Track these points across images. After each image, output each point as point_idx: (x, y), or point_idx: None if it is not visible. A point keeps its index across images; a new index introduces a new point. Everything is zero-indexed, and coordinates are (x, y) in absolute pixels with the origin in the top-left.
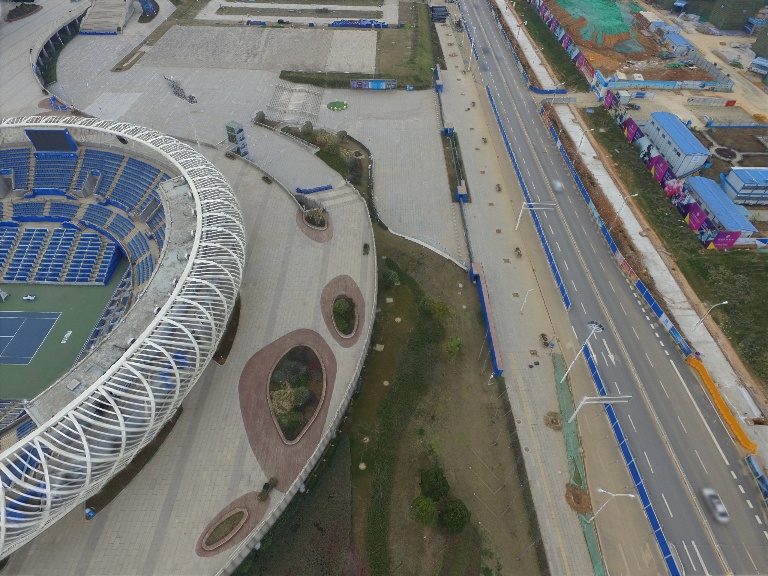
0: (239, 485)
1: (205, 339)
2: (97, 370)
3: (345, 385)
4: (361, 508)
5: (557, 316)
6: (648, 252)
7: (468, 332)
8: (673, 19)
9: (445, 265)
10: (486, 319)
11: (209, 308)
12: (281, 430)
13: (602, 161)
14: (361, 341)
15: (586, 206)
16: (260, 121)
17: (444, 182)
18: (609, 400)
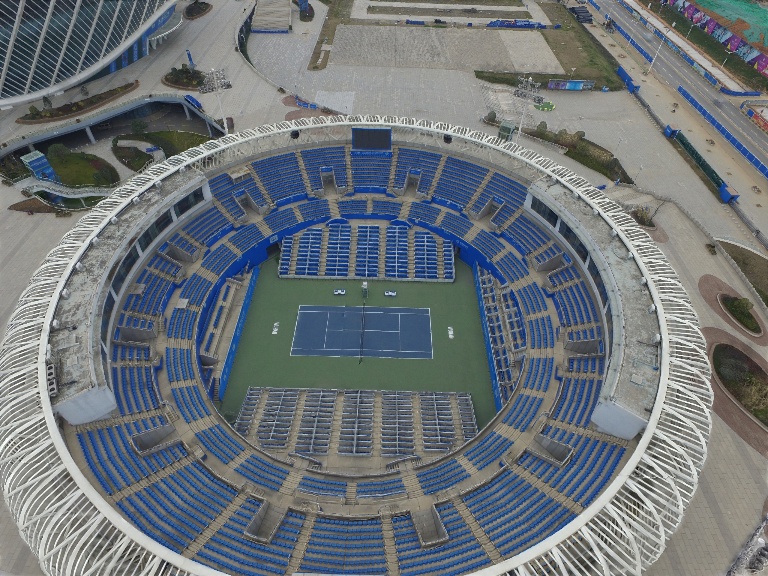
0: (763, 479)
1: None
2: (644, 365)
3: None
4: None
5: None
6: None
7: None
8: None
9: (767, 266)
10: None
11: None
12: (766, 426)
13: None
14: None
15: None
16: (492, 121)
17: (699, 183)
18: None
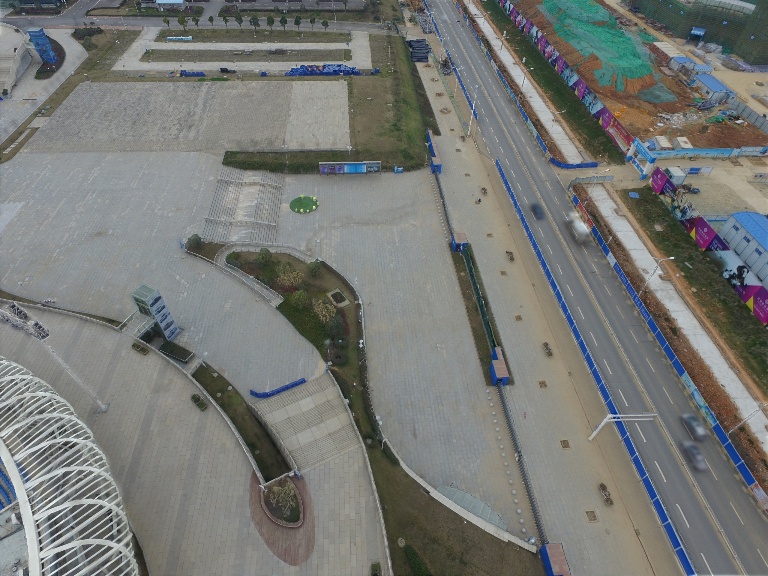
0: None
1: None
2: None
3: None
4: None
5: None
6: None
7: None
8: (693, 51)
9: (504, 557)
10: None
11: None
12: None
13: (673, 284)
14: None
15: (677, 377)
16: (194, 249)
17: (468, 343)
18: None
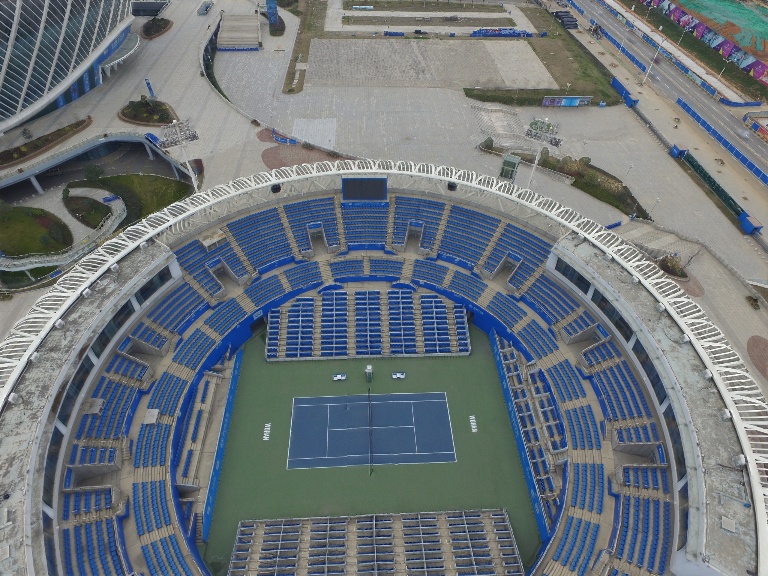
0: None
1: None
2: (732, 501)
3: None
4: None
5: None
6: None
7: None
8: None
9: None
10: None
11: None
12: None
13: None
14: None
15: None
16: (489, 148)
17: (717, 212)
18: None
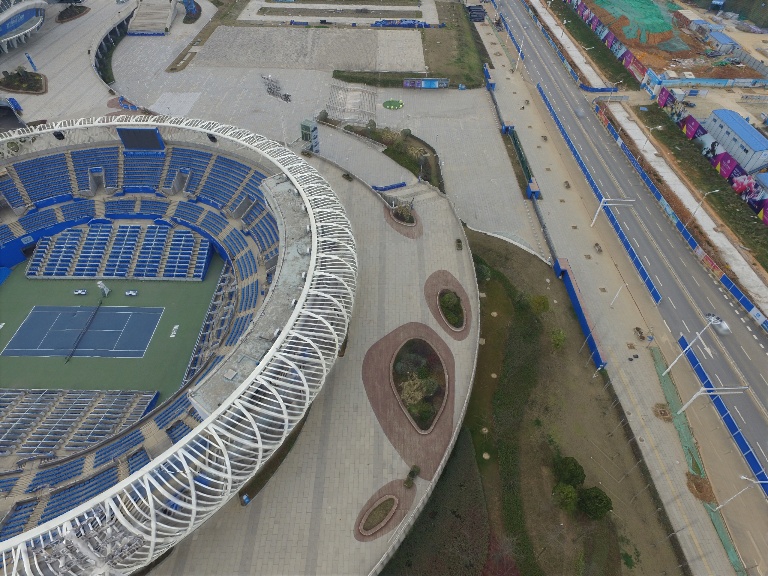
0: (383, 473)
1: (341, 331)
2: (249, 360)
3: (466, 377)
4: (493, 496)
5: (647, 310)
6: (726, 247)
7: (564, 326)
8: (712, 17)
9: (531, 260)
10: (580, 313)
11: (341, 301)
12: (413, 420)
13: (664, 158)
14: (472, 334)
15: (656, 202)
16: (323, 120)
17: (512, 179)
18: (724, 391)
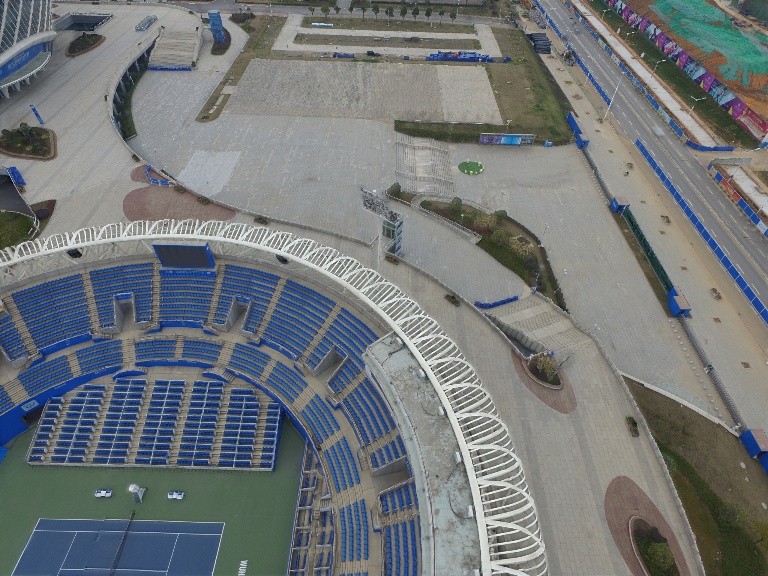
0: None
1: None
2: None
3: None
4: None
5: None
6: None
7: None
8: None
9: (717, 434)
10: None
11: None
12: None
13: None
14: None
15: None
16: (395, 195)
17: (644, 284)
18: None
